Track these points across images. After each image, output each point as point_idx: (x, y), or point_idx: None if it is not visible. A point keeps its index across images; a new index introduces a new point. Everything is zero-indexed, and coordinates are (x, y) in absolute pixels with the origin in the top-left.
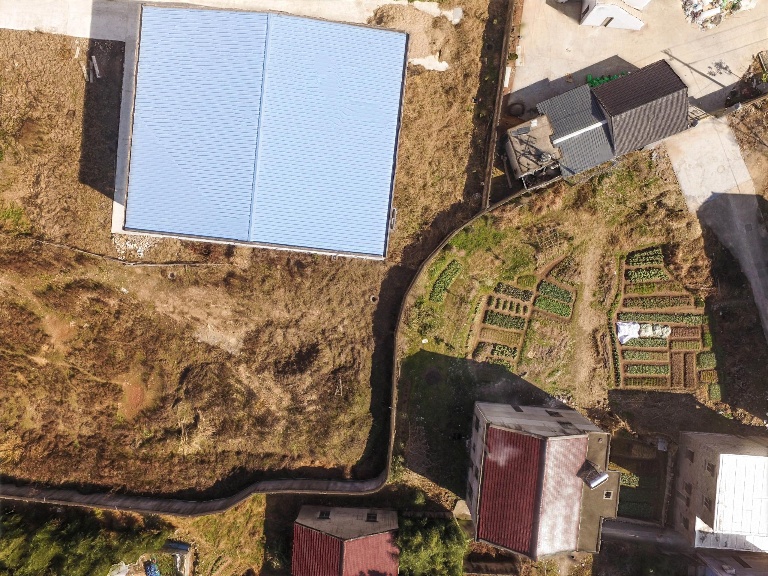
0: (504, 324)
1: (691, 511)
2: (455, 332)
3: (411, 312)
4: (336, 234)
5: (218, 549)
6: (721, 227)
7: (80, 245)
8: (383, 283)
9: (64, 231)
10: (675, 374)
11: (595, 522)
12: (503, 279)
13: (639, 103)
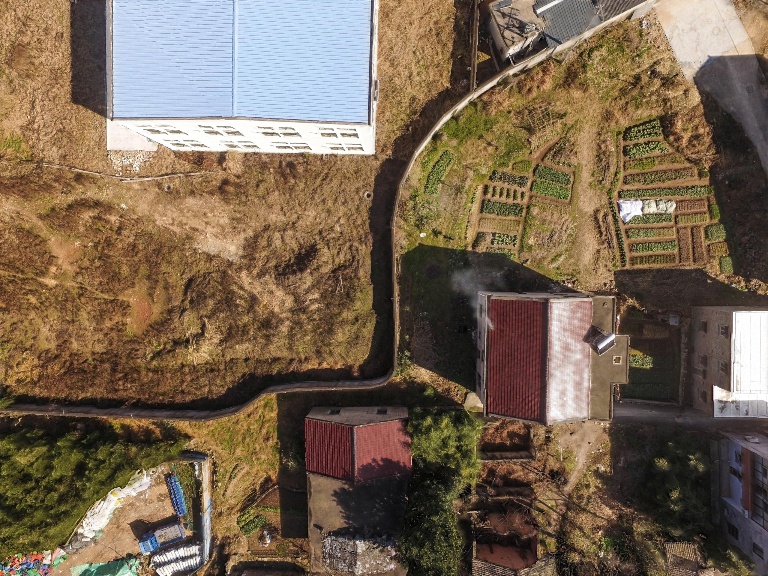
0: (502, 212)
1: (708, 382)
2: (453, 223)
3: (406, 204)
4: (319, 105)
5: (234, 457)
6: (721, 91)
7: (78, 165)
8: (376, 178)
9: (62, 153)
10: (683, 249)
11: (606, 389)
12: (498, 166)
13: None
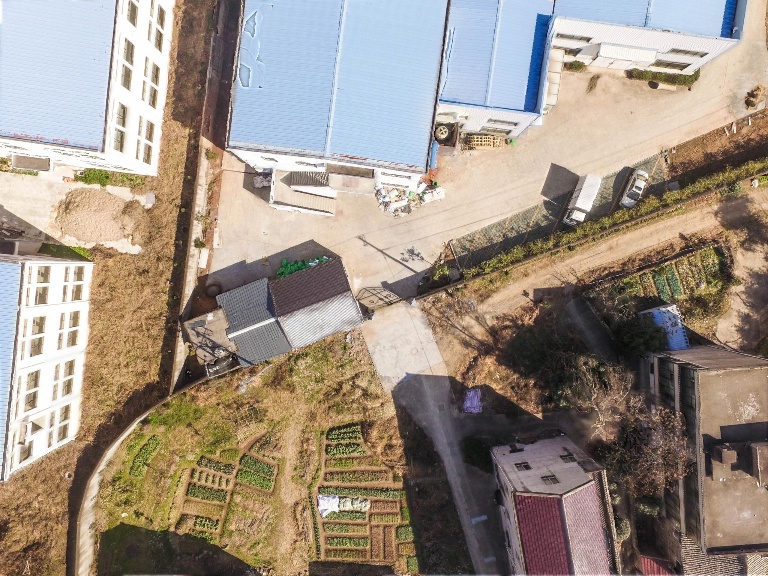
0: (206, 497)
1: None
2: (155, 506)
3: None
4: None
5: None
6: (415, 407)
7: None
8: (79, 459)
9: None
10: (374, 547)
11: None
12: (205, 453)
13: (305, 304)
